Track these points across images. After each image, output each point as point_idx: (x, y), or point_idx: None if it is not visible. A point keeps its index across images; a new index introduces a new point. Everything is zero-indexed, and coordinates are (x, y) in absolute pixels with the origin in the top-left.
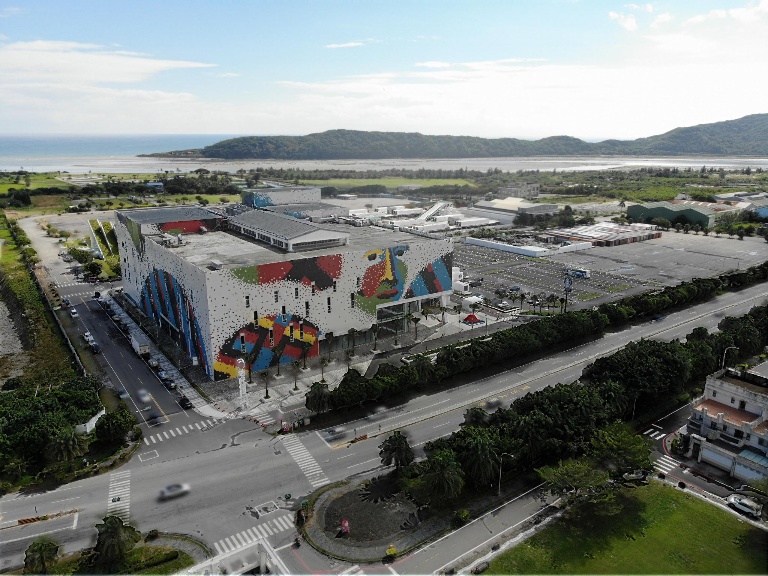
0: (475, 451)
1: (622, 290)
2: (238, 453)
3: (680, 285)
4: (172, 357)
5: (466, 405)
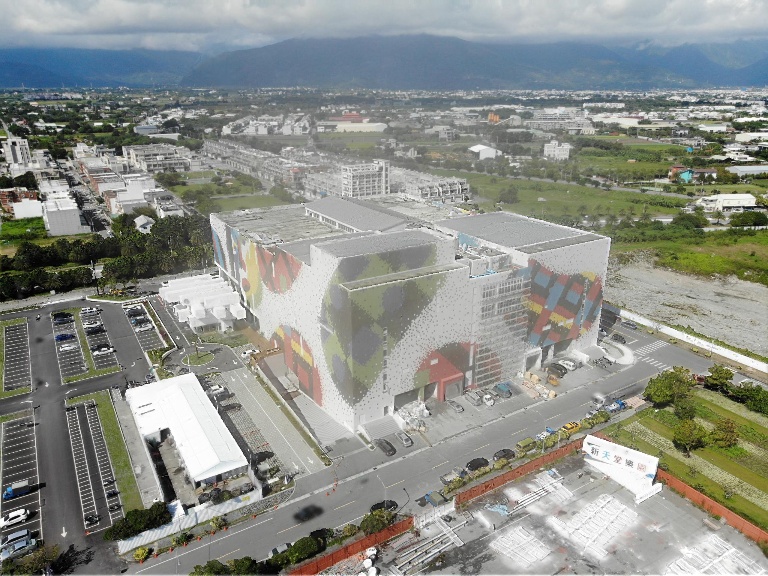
0: None
1: None
2: None
3: None
4: None
5: None
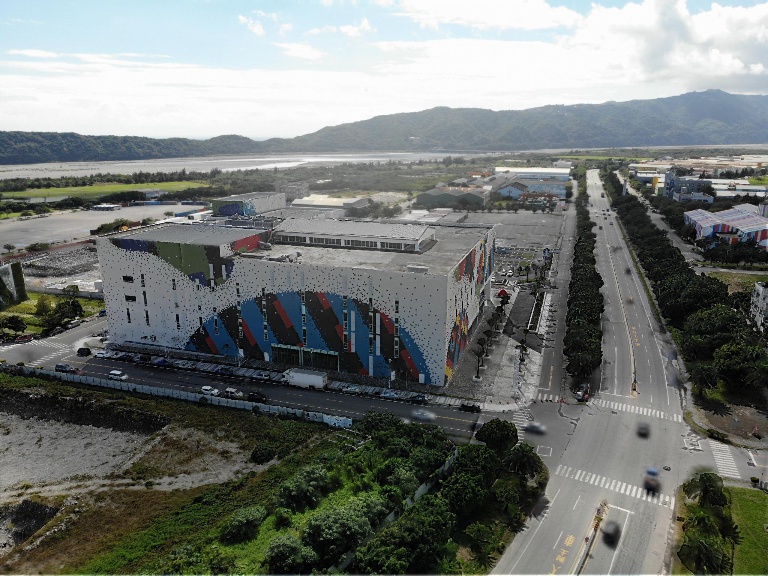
0: (763, 358)
1: (534, 257)
2: (594, 423)
3: (583, 245)
4: (355, 381)
5: (633, 347)
